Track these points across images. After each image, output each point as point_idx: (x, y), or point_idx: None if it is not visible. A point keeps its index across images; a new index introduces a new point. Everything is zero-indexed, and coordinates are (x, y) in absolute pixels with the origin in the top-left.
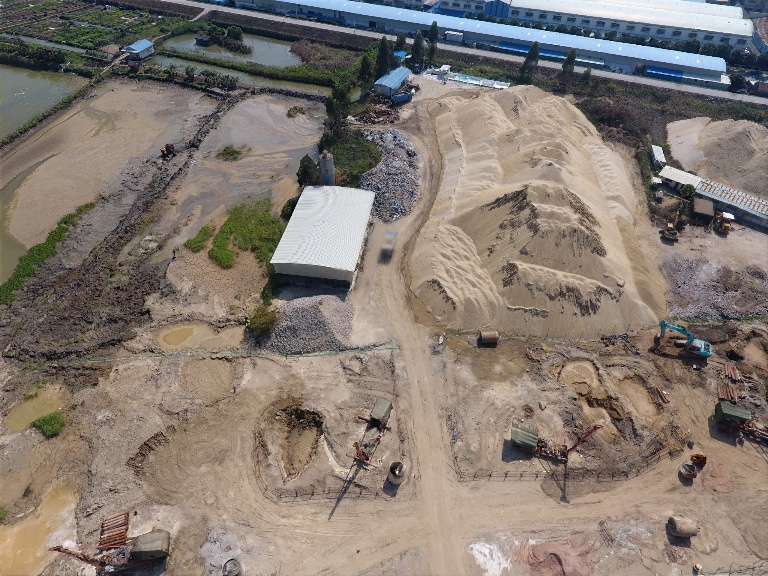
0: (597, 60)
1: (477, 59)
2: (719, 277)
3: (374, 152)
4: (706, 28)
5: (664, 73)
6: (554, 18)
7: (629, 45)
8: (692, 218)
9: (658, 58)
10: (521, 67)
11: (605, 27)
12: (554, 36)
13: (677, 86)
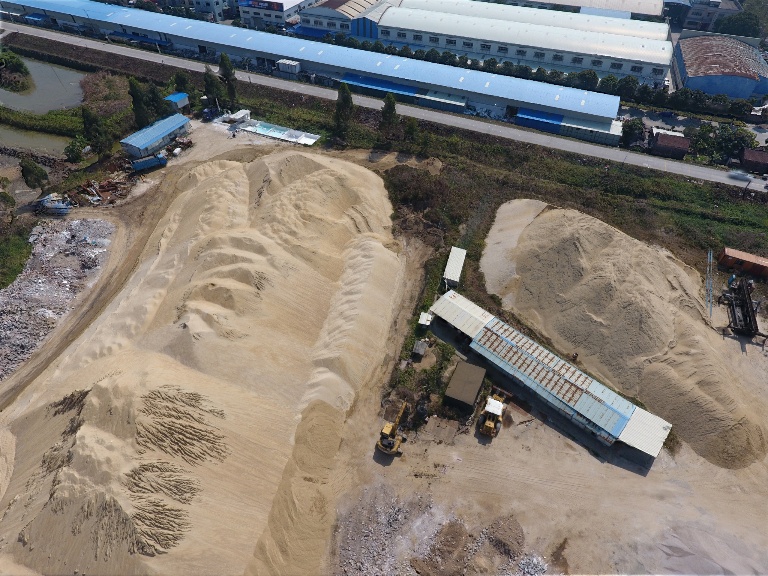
0: (457, 99)
1: (299, 99)
2: (429, 553)
3: (2, 270)
4: (612, 54)
5: (538, 118)
6: (431, 40)
7: (501, 79)
8: (444, 402)
9: (532, 98)
10: (333, 115)
11: (491, 51)
12: (409, 67)
13: (545, 139)
